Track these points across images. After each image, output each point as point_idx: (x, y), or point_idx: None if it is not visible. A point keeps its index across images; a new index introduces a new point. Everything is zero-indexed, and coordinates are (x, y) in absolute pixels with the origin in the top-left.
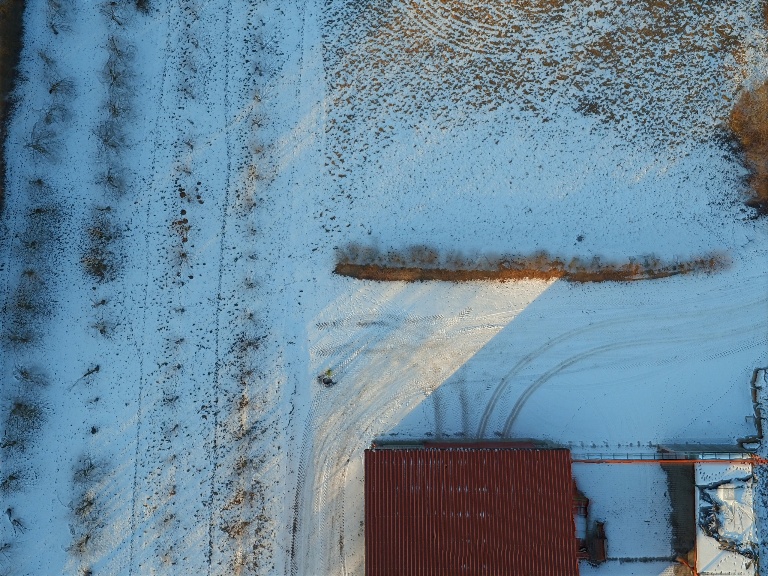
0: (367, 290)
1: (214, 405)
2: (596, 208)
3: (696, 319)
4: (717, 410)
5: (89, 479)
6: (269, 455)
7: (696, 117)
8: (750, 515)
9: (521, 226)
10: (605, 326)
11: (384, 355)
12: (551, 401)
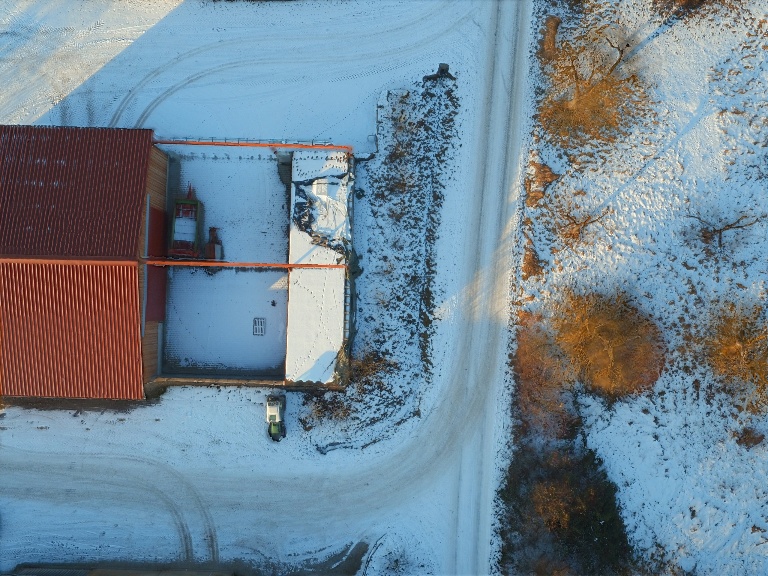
0: (1, 1)
1: None
2: None
3: (327, 42)
4: (341, 129)
5: None
6: None
7: None
8: (344, 212)
9: None
10: (234, 44)
11: (14, 64)
12: (176, 113)
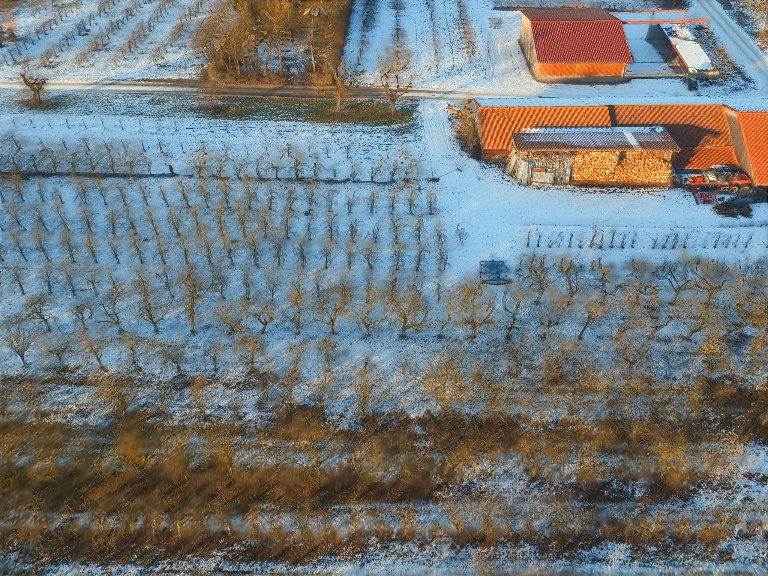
0: (507, 12)
1: None
2: None
3: None
4: None
5: (400, 29)
6: None
7: None
8: None
9: None
10: None
11: None
12: None
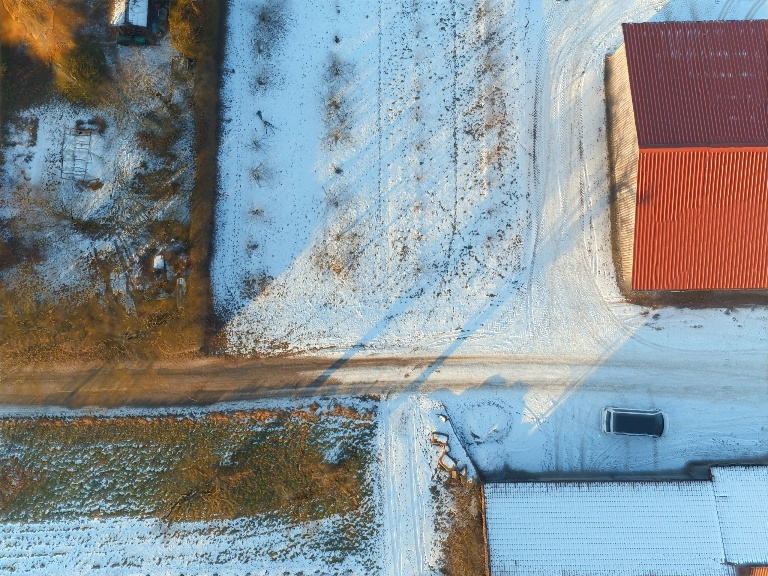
0: None
1: (452, 18)
2: None
3: None
4: None
5: (341, 75)
6: (508, 64)
7: None
8: None
9: None
10: None
11: None
12: None
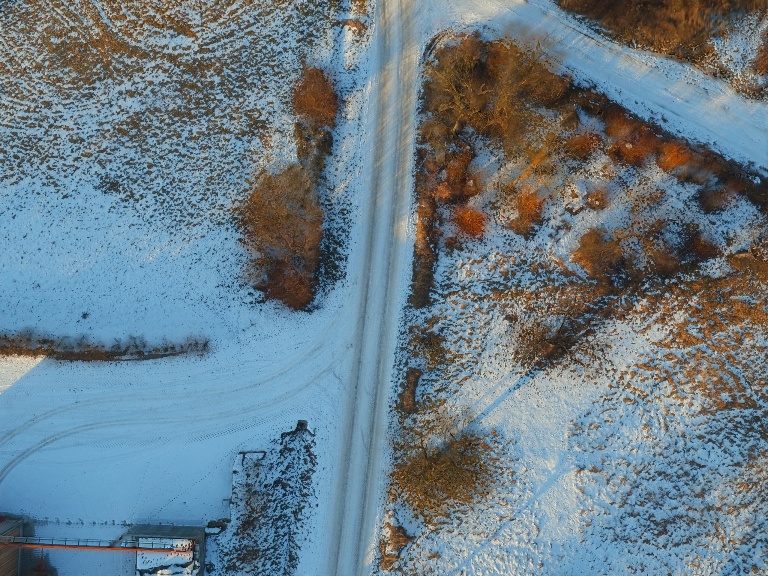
0: None
1: None
2: (105, 286)
3: (184, 401)
4: (196, 492)
5: None
6: None
7: (215, 199)
8: None
9: (27, 301)
10: (91, 405)
11: None
12: (31, 477)
